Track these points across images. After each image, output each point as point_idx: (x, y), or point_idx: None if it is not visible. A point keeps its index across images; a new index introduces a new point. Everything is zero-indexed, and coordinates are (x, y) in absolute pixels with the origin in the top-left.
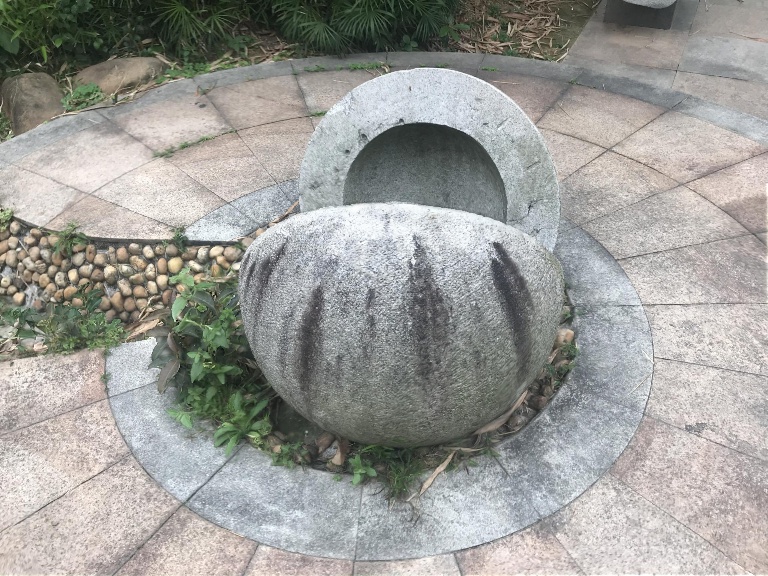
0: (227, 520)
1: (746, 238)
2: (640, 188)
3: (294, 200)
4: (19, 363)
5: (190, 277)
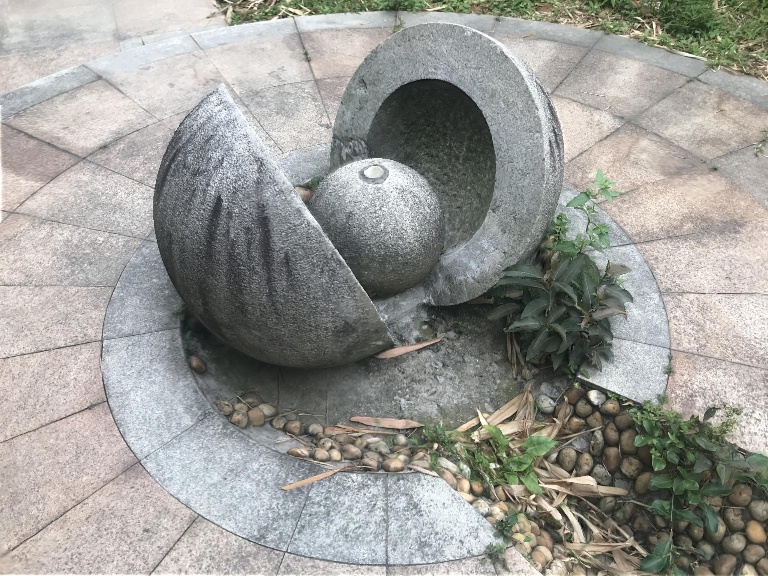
0: (610, 222)
1: (94, 159)
2: (39, 231)
3: (303, 491)
4: (767, 453)
5: (598, 178)
